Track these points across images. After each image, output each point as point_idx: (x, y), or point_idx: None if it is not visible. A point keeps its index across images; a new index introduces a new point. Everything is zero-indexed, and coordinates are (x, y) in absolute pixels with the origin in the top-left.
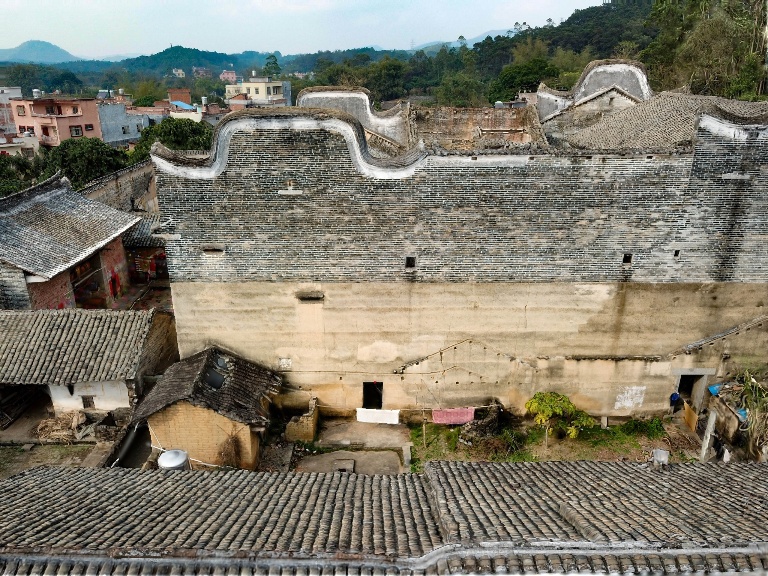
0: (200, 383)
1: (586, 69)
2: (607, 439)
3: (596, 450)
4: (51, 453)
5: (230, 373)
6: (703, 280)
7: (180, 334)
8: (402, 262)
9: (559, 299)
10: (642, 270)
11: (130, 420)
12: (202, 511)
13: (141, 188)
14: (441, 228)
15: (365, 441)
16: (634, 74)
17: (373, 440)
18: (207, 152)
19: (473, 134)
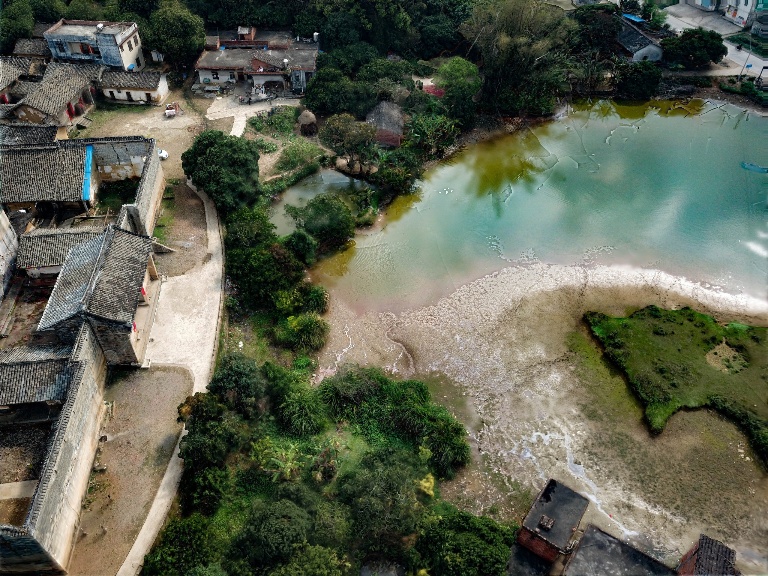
0: None
1: None
2: None
3: None
4: None
5: None
6: None
7: None
8: None
9: None
10: None
11: None
12: (5, 174)
13: None
14: None
15: None
16: None
17: None
18: None
19: None
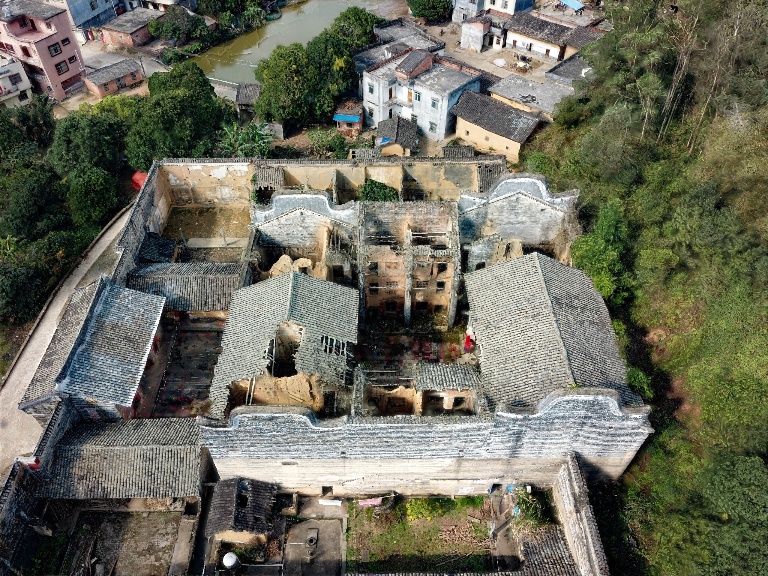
0: (236, 512)
1: (498, 180)
2: (452, 509)
3: (443, 519)
4: (159, 520)
5: (250, 494)
6: (502, 457)
7: (220, 473)
8: (339, 453)
9: (425, 463)
10: (469, 455)
11: (200, 510)
12: None
13: (148, 208)
14: (359, 443)
15: (324, 513)
16: (536, 183)
17: (328, 513)
18: (196, 161)
19: (406, 239)
